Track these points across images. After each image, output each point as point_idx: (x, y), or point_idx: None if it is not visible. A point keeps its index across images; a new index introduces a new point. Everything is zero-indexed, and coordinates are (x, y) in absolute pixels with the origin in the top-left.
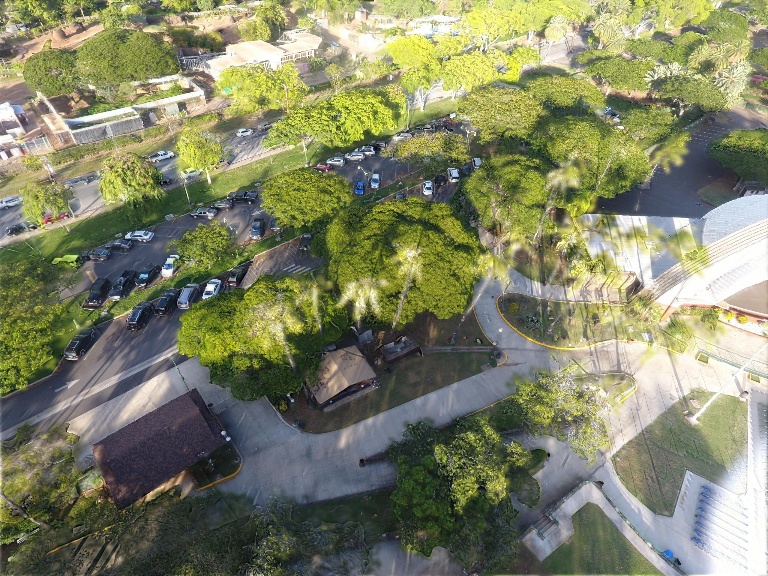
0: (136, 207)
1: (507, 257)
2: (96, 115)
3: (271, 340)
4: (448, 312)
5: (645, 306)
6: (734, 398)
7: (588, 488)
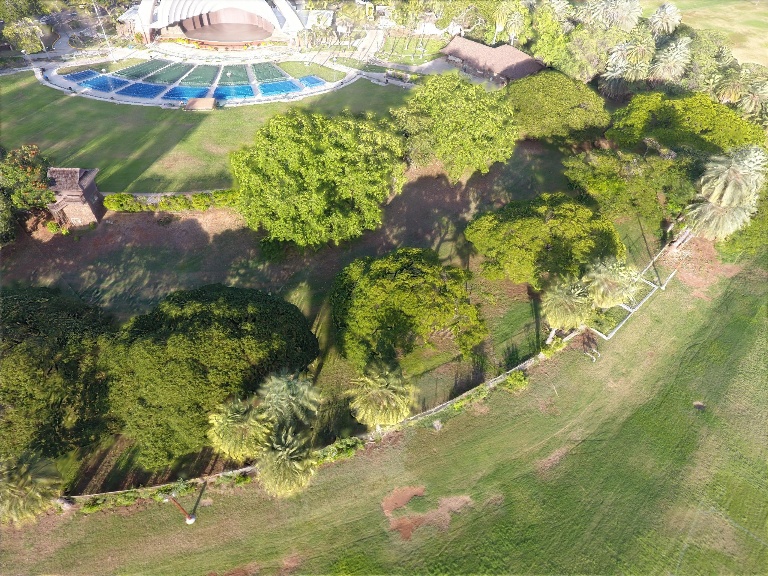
0: None
1: (98, 27)
2: None
3: None
4: (8, 19)
5: (85, 8)
6: None
7: (35, 68)
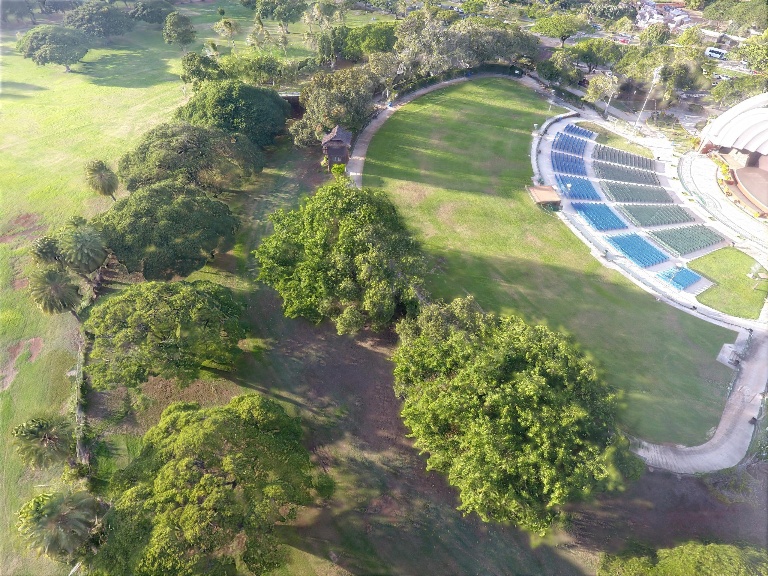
0: (642, 44)
1: None
2: (704, 30)
3: (585, 44)
4: None
5: None
6: (653, 157)
7: None
